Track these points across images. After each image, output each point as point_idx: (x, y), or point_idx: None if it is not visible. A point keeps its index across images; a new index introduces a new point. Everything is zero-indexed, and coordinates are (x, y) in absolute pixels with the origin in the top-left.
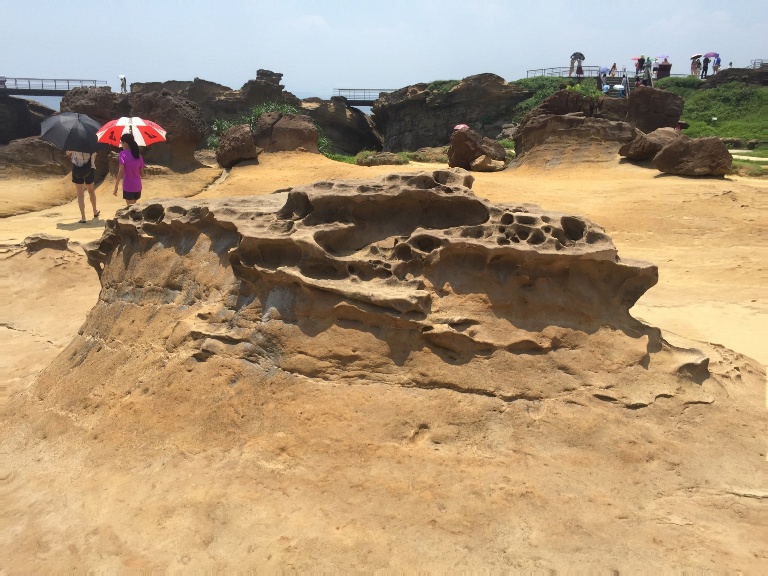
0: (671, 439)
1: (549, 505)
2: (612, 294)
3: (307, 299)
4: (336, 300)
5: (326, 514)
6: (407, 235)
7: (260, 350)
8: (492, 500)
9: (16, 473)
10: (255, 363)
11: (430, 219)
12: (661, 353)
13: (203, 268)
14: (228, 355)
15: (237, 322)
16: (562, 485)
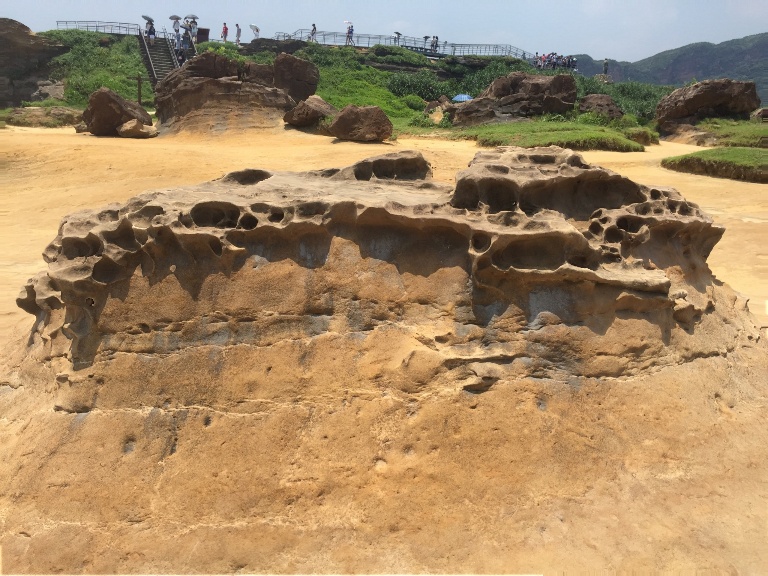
0: None
1: None
2: None
3: (586, 296)
4: (612, 292)
5: None
6: (594, 217)
7: (545, 362)
8: None
9: None
10: (543, 378)
11: (580, 199)
12: None
13: (369, 280)
14: (512, 376)
15: (497, 337)
16: None
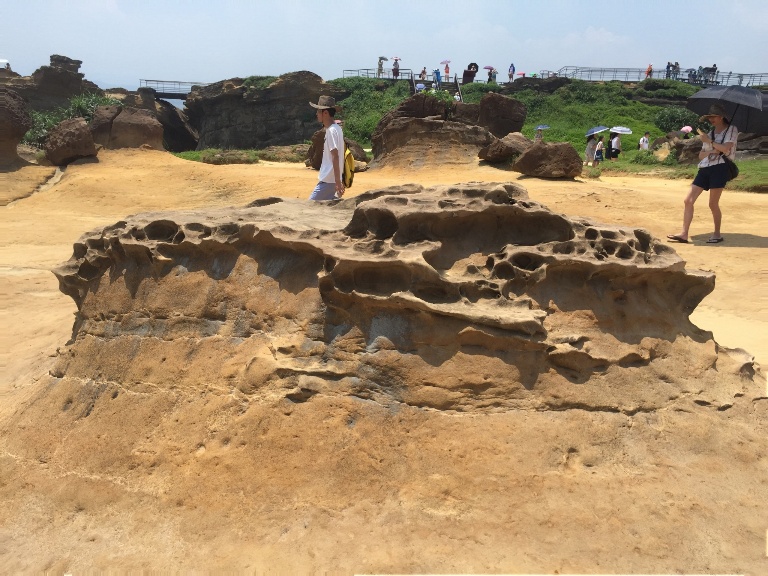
0: (763, 436)
1: (716, 515)
2: (675, 302)
3: (425, 326)
4: (458, 325)
5: (534, 558)
6: (497, 252)
7: (372, 384)
8: (672, 518)
9: (65, 560)
10: (368, 399)
11: (505, 234)
12: (719, 355)
13: (256, 294)
14: (334, 393)
15: (334, 355)
16: (712, 493)
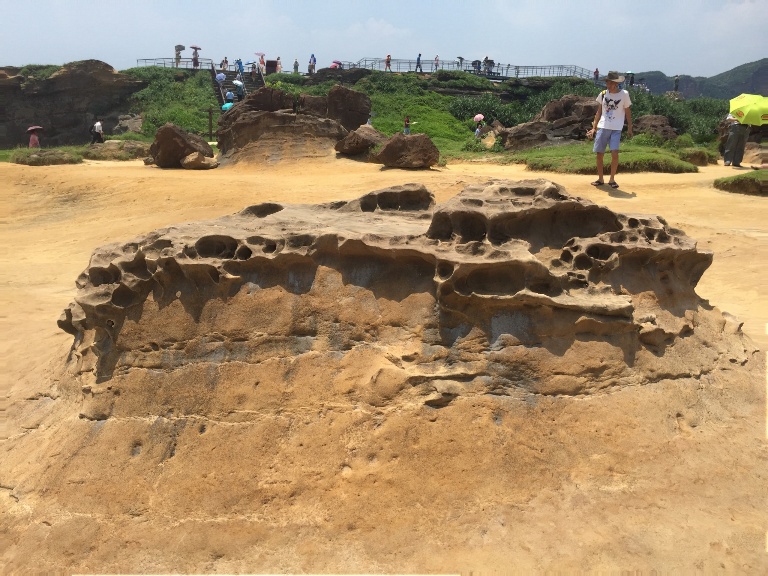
0: None
1: None
2: (686, 278)
3: (545, 319)
4: (572, 316)
5: (709, 512)
6: (567, 245)
7: (504, 380)
8: None
9: None
10: (502, 395)
11: (558, 228)
12: None
13: (348, 305)
14: (472, 393)
15: (460, 357)
16: None
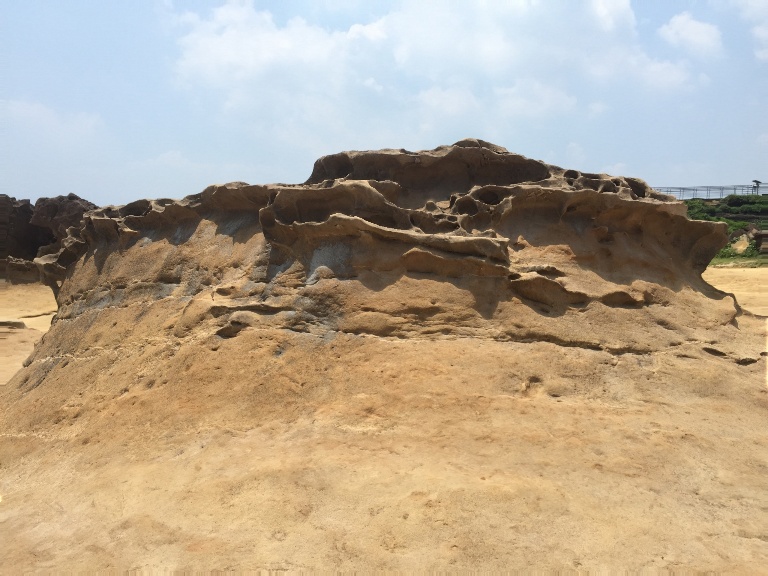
0: None
1: (717, 447)
2: (683, 258)
3: (367, 250)
4: (404, 248)
5: (459, 467)
6: None
7: (308, 316)
8: (654, 442)
9: None
10: (303, 332)
11: None
12: (743, 317)
13: (210, 252)
14: (266, 326)
15: (272, 291)
16: (717, 430)
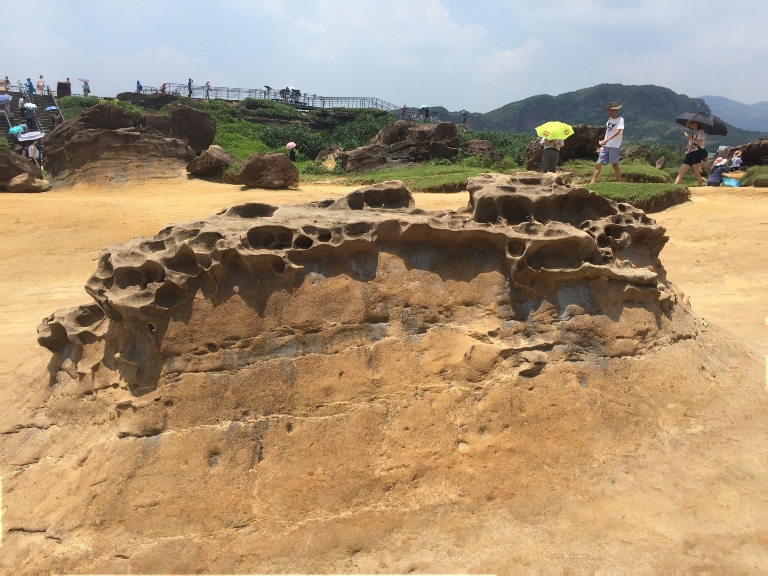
0: None
1: None
2: None
3: (602, 289)
4: (619, 286)
5: None
6: None
7: (577, 347)
8: None
9: None
10: (577, 361)
11: (565, 214)
12: None
13: (417, 289)
14: (556, 361)
15: (537, 329)
16: None
